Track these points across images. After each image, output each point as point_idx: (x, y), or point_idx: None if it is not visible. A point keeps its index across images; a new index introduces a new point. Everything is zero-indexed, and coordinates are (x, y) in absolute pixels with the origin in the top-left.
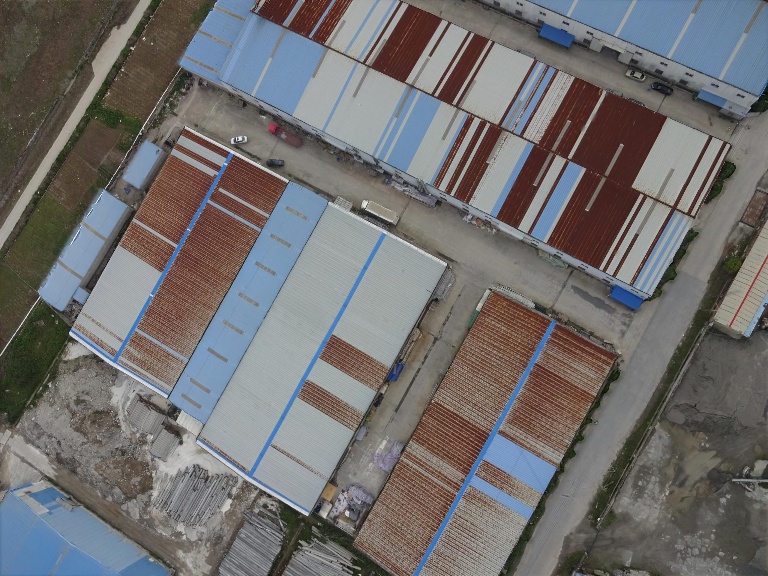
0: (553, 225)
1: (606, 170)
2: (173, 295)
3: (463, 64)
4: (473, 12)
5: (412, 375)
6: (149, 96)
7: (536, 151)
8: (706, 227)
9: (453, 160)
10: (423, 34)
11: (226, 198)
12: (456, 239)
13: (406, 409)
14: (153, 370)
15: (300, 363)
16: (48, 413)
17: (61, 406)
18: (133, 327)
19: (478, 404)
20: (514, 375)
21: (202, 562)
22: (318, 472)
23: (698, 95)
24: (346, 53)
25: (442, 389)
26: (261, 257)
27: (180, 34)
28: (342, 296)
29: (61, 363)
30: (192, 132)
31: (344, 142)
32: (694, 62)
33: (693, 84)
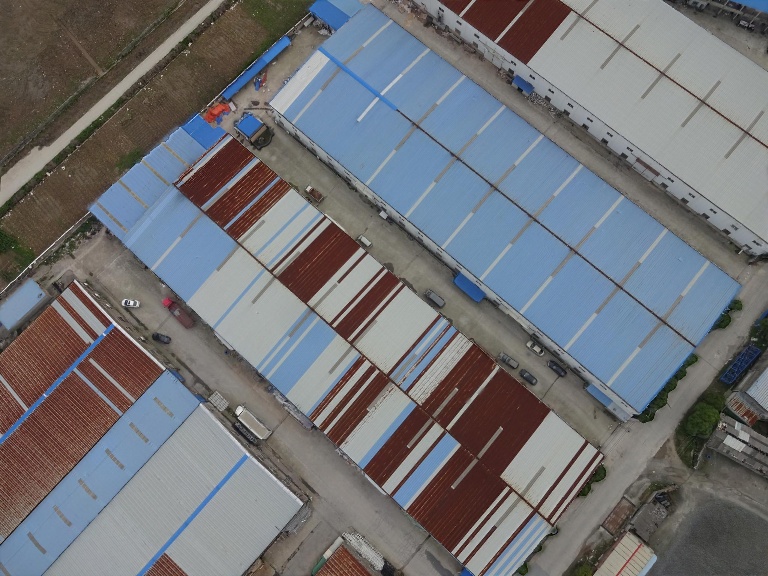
0: (416, 494)
1: (480, 452)
2: (8, 463)
3: (369, 300)
4: (397, 238)
5: None
6: (51, 230)
7: (417, 412)
8: (568, 523)
9: (335, 397)
10: (338, 257)
11: (95, 371)
12: (324, 470)
13: None
14: None
15: None
16: None
17: None
18: None
19: None
20: None
21: None
22: None
23: (587, 388)
24: (256, 256)
25: None
26: (114, 445)
27: (101, 174)
28: (186, 512)
29: None
30: (80, 288)
31: (231, 346)
32: (587, 361)
33: (585, 376)
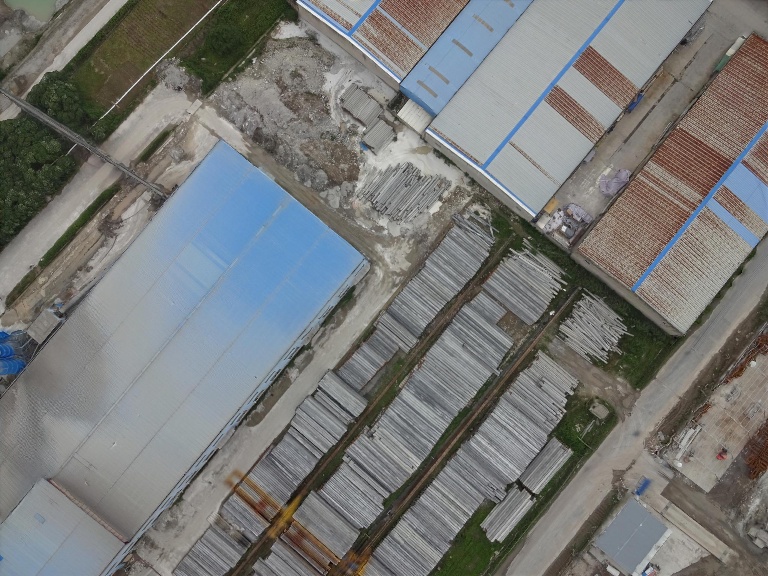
0: None
1: None
2: None
3: None
4: None
5: (646, 110)
6: None
7: None
8: None
9: None
10: None
11: None
12: None
13: (635, 141)
14: (389, 52)
15: (551, 68)
16: (256, 83)
17: (270, 80)
18: (374, 4)
19: (725, 134)
20: (765, 112)
21: (402, 258)
22: (552, 177)
23: None
24: None
25: (689, 117)
26: None
27: None
28: (605, 10)
29: (270, 40)
30: None
31: None
32: None
33: None
